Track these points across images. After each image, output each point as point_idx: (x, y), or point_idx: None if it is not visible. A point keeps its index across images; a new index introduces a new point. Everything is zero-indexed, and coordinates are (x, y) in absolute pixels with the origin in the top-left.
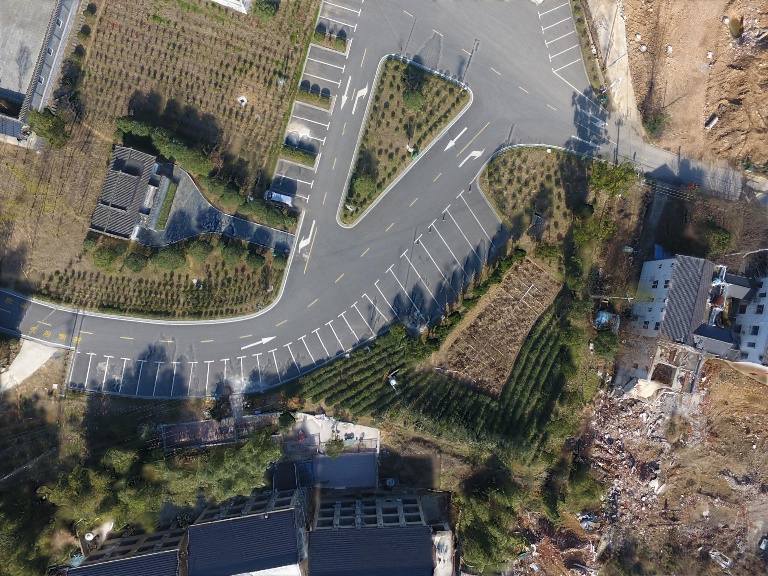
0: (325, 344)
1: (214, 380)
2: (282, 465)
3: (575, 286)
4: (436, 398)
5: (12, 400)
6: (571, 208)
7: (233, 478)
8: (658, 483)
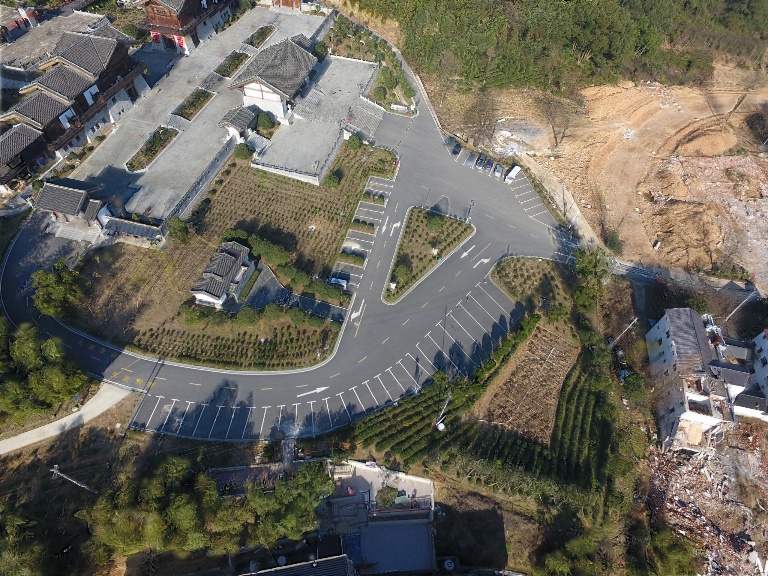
0: (374, 394)
1: (269, 424)
2: (327, 537)
3: (590, 338)
4: (486, 448)
5: (72, 439)
6: (569, 295)
7: (283, 511)
8: (759, 559)
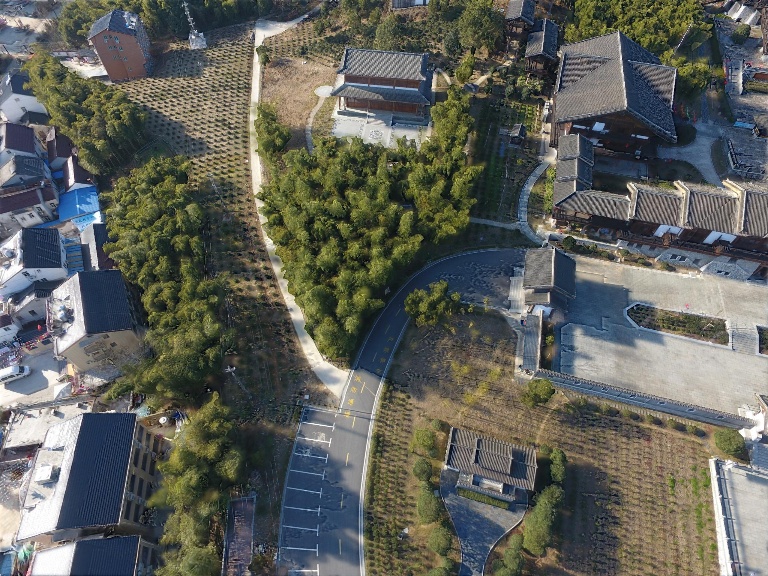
0: None
1: (296, 557)
2: None
3: None
4: None
5: (298, 364)
6: None
7: None
8: None
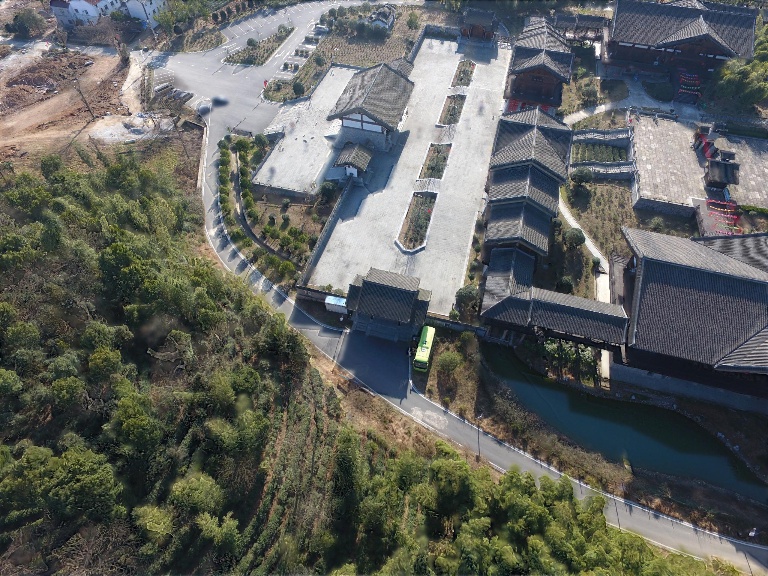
0: (308, 5)
1: None
2: None
3: None
4: None
5: None
6: None
7: None
8: None
